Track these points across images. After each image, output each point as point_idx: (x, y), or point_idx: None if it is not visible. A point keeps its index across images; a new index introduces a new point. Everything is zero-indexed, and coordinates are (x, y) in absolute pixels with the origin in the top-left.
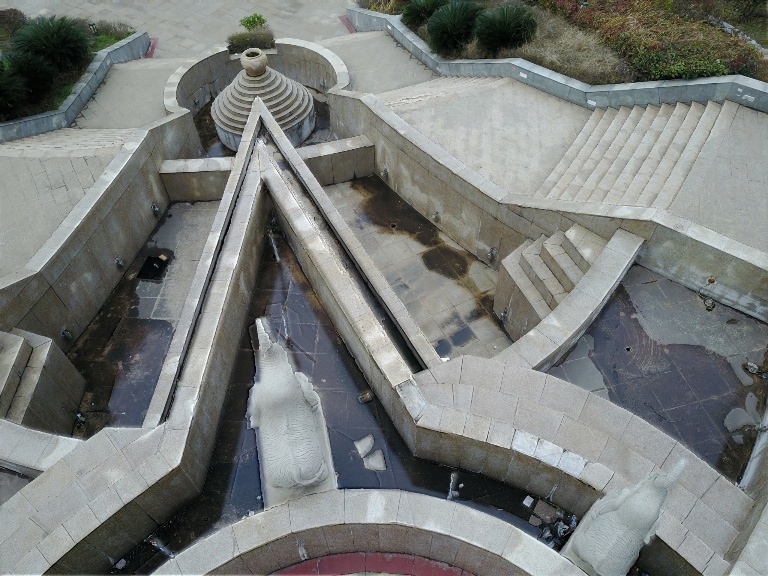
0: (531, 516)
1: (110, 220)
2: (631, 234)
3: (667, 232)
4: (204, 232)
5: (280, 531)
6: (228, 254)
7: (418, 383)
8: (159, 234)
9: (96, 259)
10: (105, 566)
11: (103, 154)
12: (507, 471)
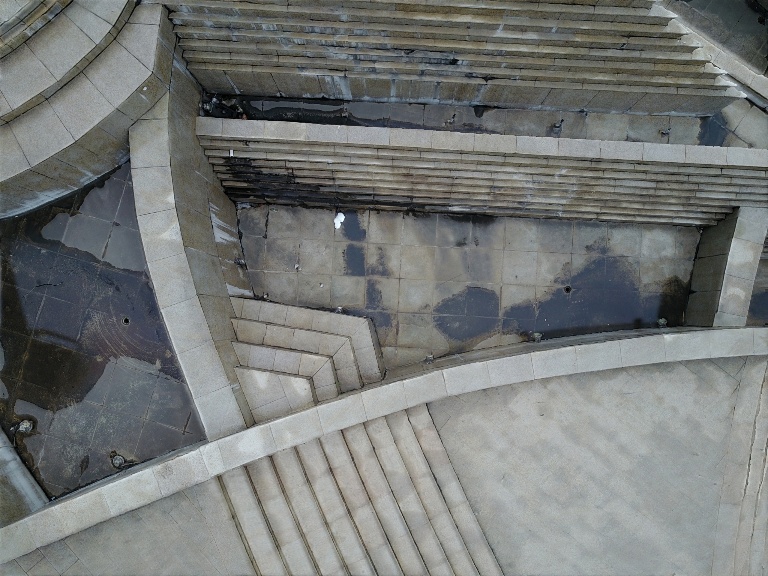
0: None
1: None
2: (227, 434)
3: None
4: None
5: None
6: None
7: (148, 4)
8: None
9: None
10: None
11: None
12: None
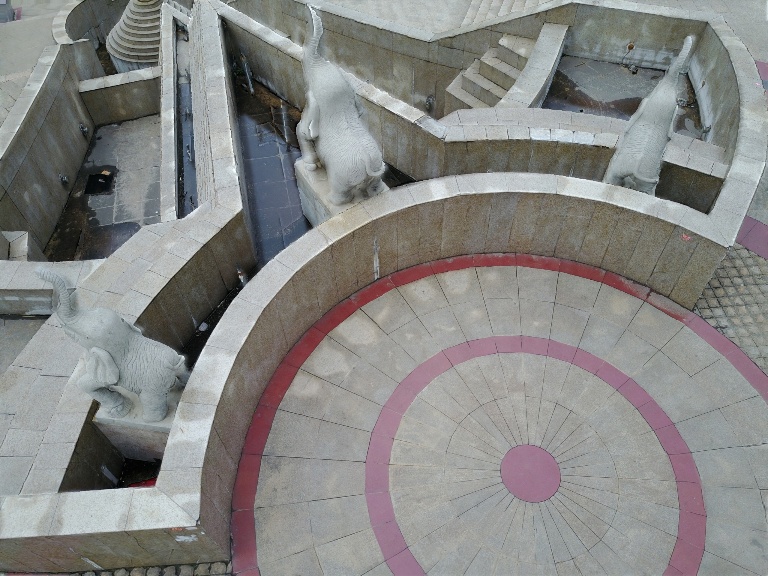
0: None
1: (46, 131)
2: (556, 24)
3: (587, 10)
4: (141, 144)
5: (362, 221)
6: (213, 68)
7: None
8: (94, 155)
9: (41, 171)
10: (190, 327)
11: (15, 78)
12: None
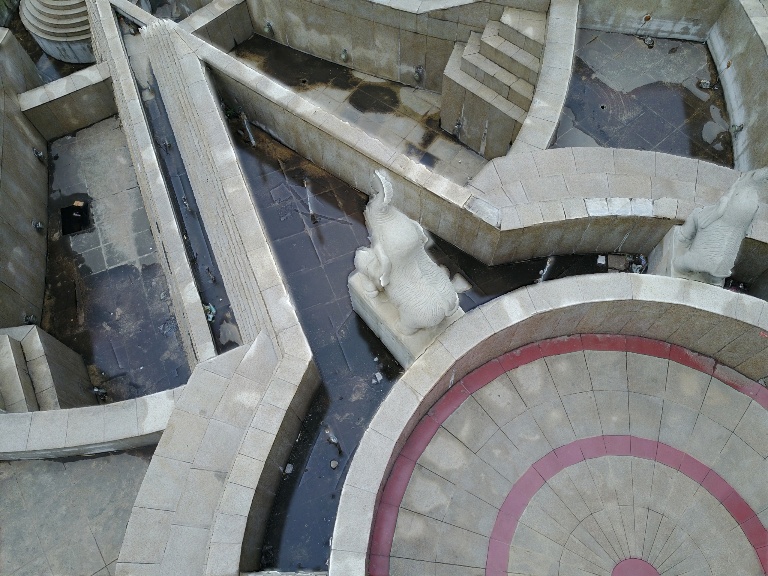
0: (608, 270)
1: (6, 181)
2: None
3: None
4: (107, 160)
5: (446, 364)
6: (220, 149)
7: None
8: (57, 181)
9: (15, 229)
10: (279, 476)
11: None
12: (580, 241)
